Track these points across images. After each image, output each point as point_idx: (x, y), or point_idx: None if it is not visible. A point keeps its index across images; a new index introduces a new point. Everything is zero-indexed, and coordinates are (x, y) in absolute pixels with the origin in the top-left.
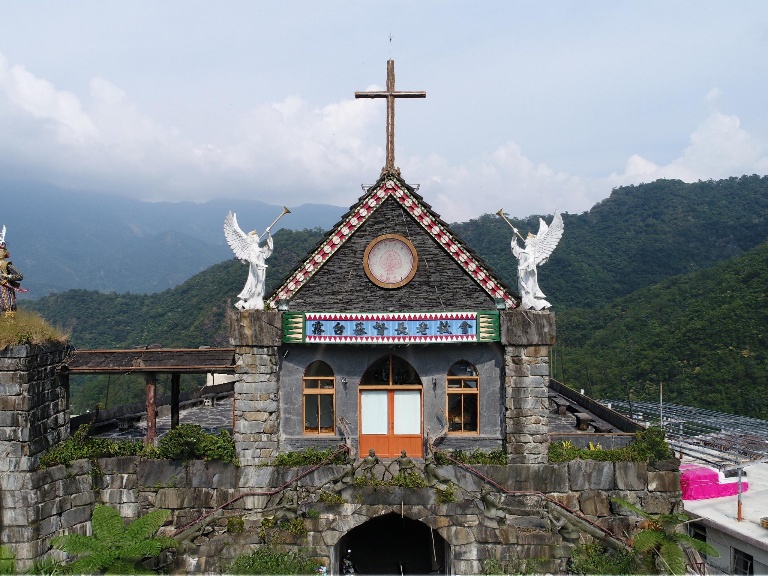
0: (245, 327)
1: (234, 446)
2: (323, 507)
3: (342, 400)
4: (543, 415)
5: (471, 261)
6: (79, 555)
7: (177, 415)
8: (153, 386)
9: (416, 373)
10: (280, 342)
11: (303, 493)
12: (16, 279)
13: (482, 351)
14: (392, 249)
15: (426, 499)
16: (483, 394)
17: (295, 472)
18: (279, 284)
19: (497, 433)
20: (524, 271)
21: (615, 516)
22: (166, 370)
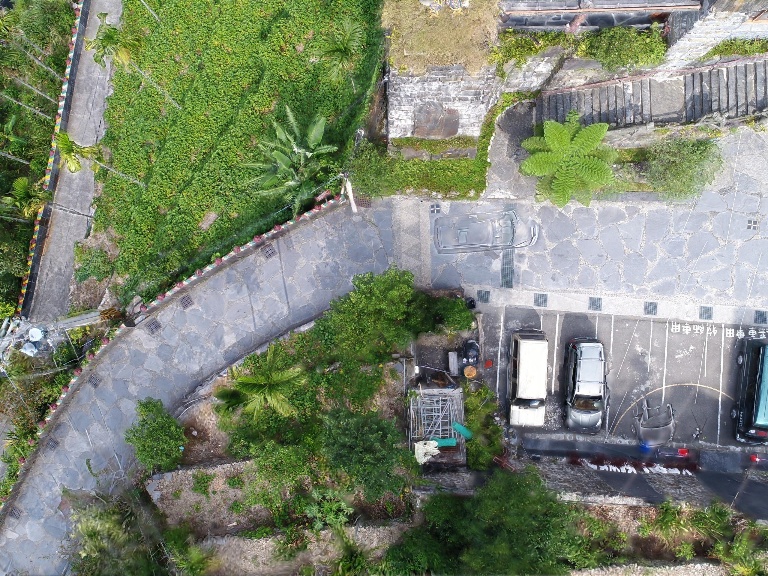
0: (737, 1)
1: (666, 51)
2: (744, 125)
3: None
4: None
5: None
6: None
7: None
8: None
9: None
10: None
11: None
12: None
13: None
14: None
15: None
16: None
17: (716, 61)
18: None
19: None
20: None
21: None
22: None
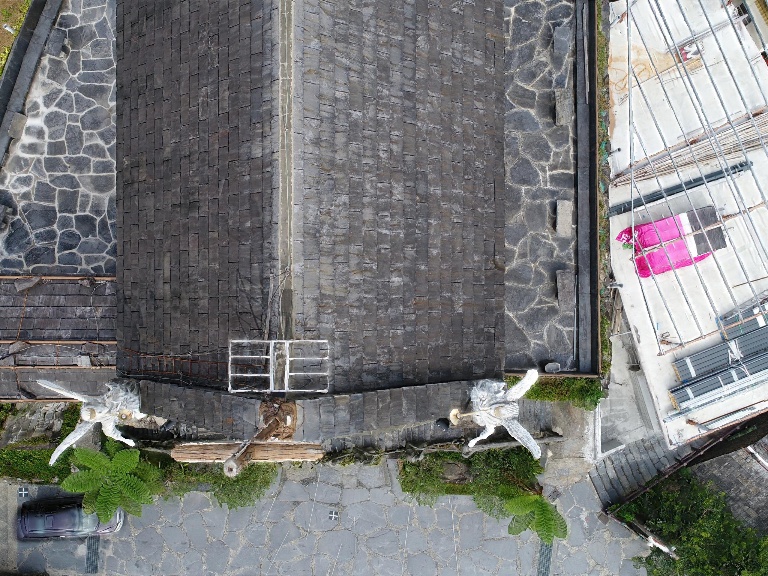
0: None
1: None
2: None
3: None
4: None
5: None
6: (91, 490)
7: None
8: None
9: None
10: None
11: None
12: None
13: None
14: None
15: None
16: None
17: None
18: None
19: None
20: None
21: None
22: None
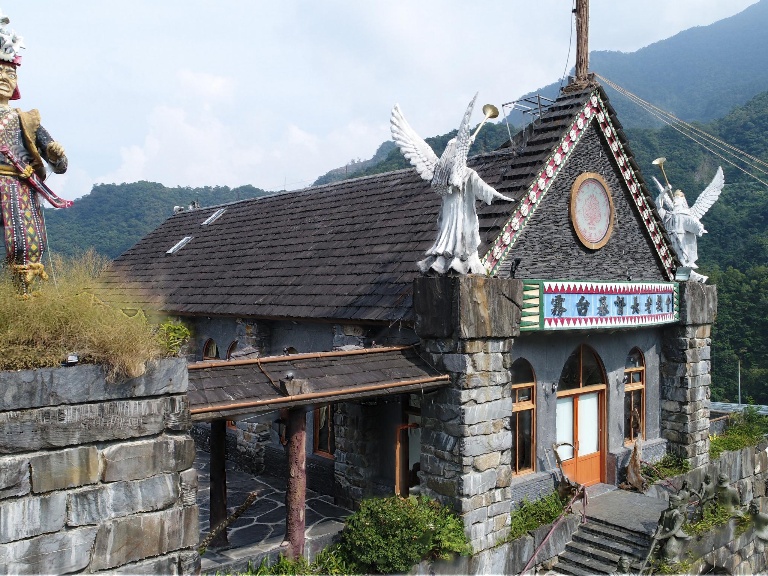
0: (480, 305)
1: (461, 522)
2: None
3: (543, 417)
4: (707, 406)
5: (651, 219)
6: None
7: (225, 489)
8: (304, 433)
9: (600, 368)
10: (519, 330)
11: (536, 574)
12: (62, 166)
13: (648, 334)
14: (593, 194)
15: (728, 535)
16: (649, 388)
17: (532, 543)
18: (498, 233)
19: (657, 435)
20: (683, 236)
21: (741, 508)
22: (353, 396)
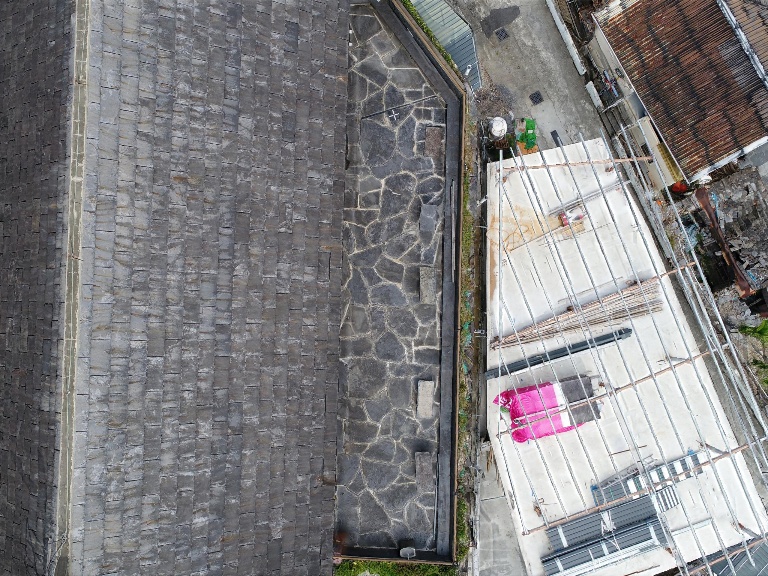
0: None
1: None
2: None
3: None
4: None
5: None
6: None
7: None
8: None
9: None
10: None
11: None
12: None
13: None
14: None
15: None
16: None
17: None
18: None
19: None
20: None
21: None
22: None
